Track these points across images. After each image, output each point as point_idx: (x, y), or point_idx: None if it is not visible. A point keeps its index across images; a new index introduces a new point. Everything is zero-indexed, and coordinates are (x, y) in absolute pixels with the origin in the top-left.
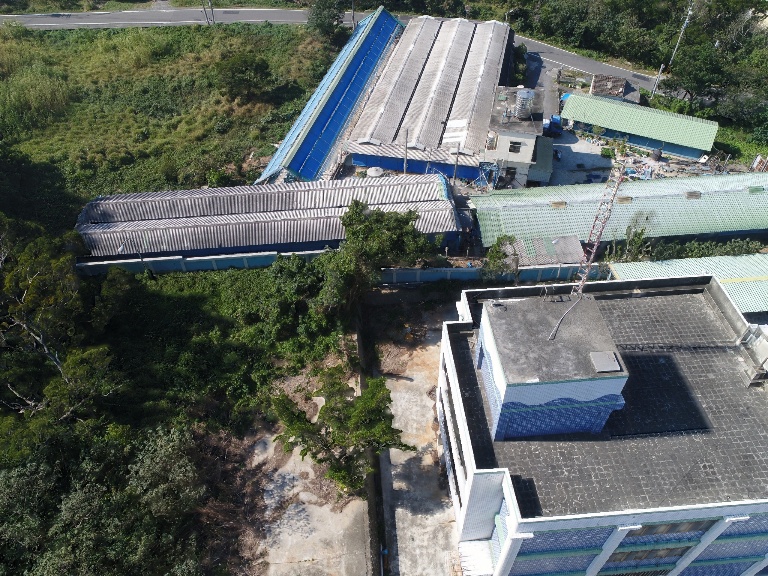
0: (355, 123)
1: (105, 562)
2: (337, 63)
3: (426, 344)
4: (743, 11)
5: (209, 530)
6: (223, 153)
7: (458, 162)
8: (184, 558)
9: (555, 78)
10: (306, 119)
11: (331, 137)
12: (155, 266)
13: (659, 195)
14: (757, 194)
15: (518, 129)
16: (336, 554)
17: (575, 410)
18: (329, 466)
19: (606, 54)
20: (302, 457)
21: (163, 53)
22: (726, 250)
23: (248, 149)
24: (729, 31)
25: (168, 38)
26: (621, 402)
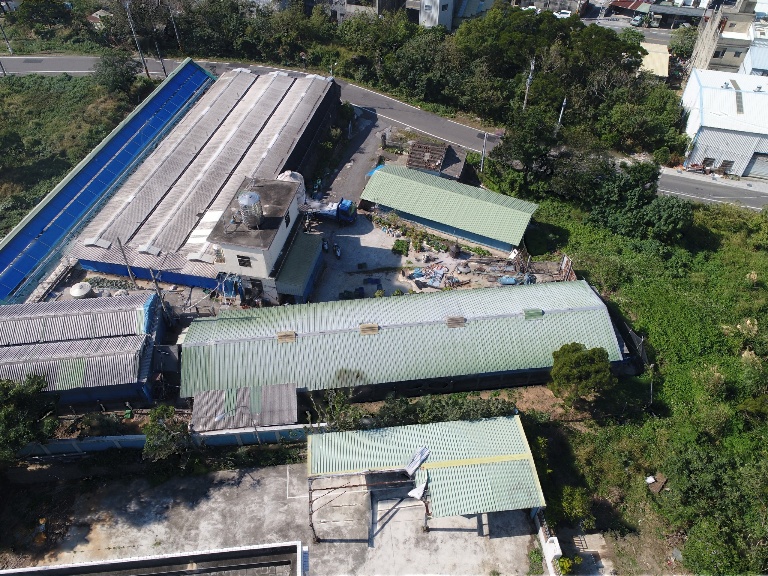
0: None
1: None
2: None
3: (59, 549)
4: (605, 60)
5: None
6: None
7: (193, 272)
8: None
9: None
10: None
11: (56, 236)
12: None
13: (414, 323)
14: (535, 320)
15: (241, 242)
16: None
17: None
18: None
19: (455, 108)
20: None
21: None
22: (457, 415)
23: None
24: (588, 83)
25: None
26: None
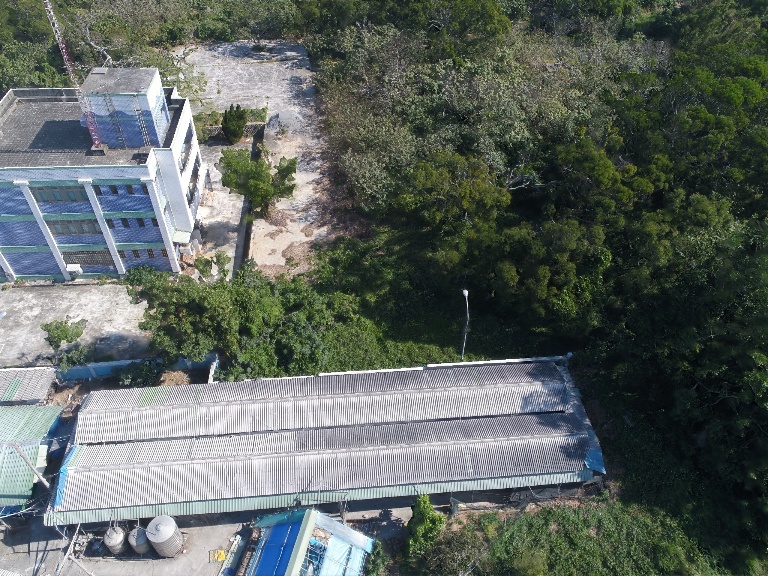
0: None
1: None
2: None
3: None
4: None
5: None
6: None
7: None
8: None
9: None
10: None
11: None
12: None
13: None
14: None
15: None
16: None
17: None
18: (276, 224)
19: None
20: None
21: None
22: None
23: None
24: None
25: None
26: None
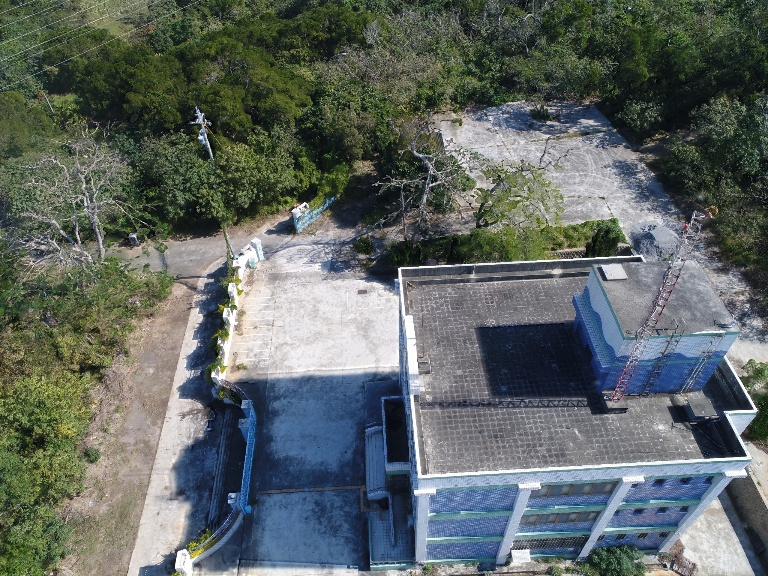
0: None
1: None
2: None
3: None
4: None
5: None
6: None
7: None
8: None
9: None
10: None
11: None
12: None
13: None
14: None
15: None
16: None
17: None
18: None
19: None
20: None
21: None
22: None
23: None
24: None
25: None
26: (578, 295)
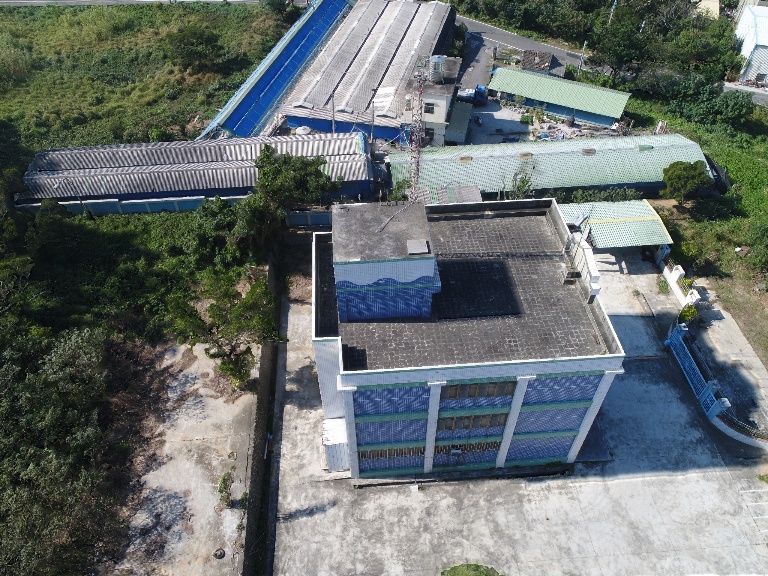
0: (294, 90)
1: (16, 426)
2: (284, 38)
3: None
4: None
5: (116, 415)
6: (170, 116)
7: (381, 123)
8: (86, 428)
9: (492, 55)
10: (247, 85)
11: (269, 101)
12: (94, 208)
13: (557, 152)
14: (646, 152)
15: (430, 91)
16: (224, 435)
17: (400, 292)
18: None
19: (545, 35)
20: (191, 347)
21: (124, 28)
22: (604, 196)
23: (194, 113)
24: (659, 14)
25: (130, 15)
26: (438, 285)
